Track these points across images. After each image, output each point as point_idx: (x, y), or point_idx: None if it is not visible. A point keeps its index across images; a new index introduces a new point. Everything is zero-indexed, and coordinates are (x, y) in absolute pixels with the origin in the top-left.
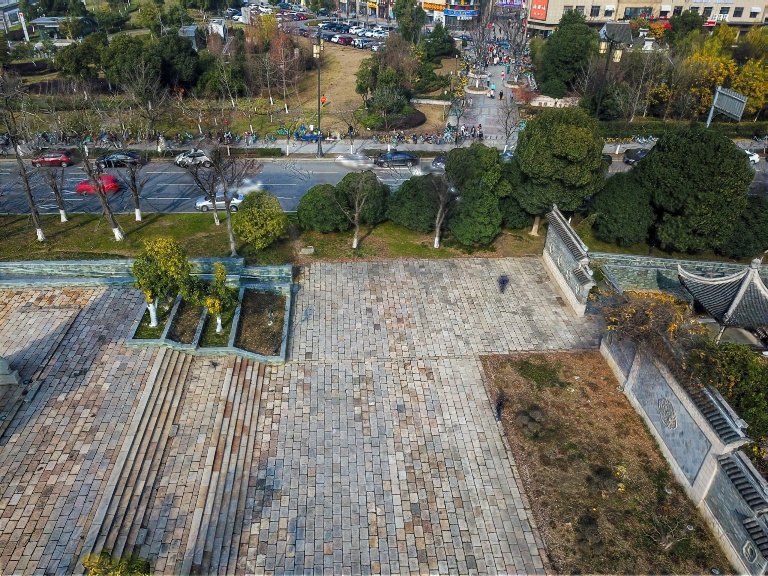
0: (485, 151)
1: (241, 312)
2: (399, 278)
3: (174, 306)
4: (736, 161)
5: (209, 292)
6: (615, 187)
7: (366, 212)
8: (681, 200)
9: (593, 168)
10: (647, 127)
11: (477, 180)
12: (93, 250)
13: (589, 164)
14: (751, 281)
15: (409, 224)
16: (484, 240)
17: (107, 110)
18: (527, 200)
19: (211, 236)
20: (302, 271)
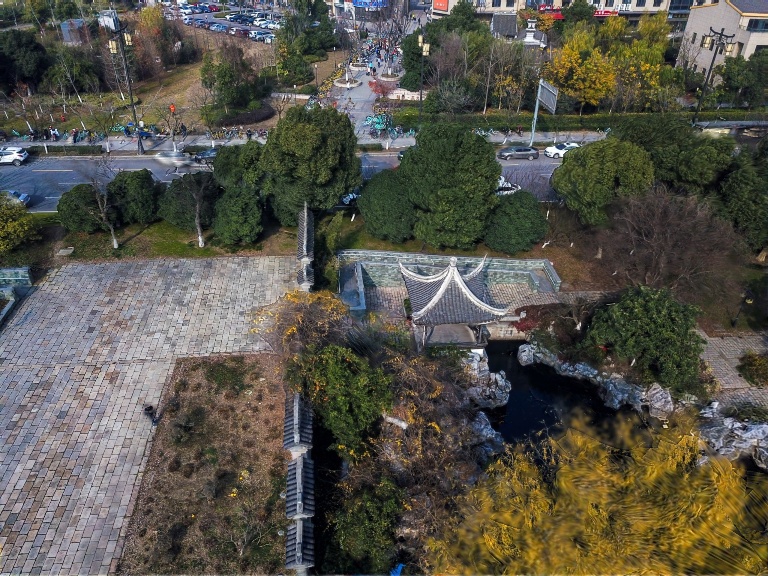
0: (246, 148)
1: None
2: (145, 279)
3: None
4: (479, 157)
5: None
6: (377, 184)
7: (137, 211)
8: (426, 197)
9: (330, 165)
10: (491, 120)
11: (236, 178)
12: None
13: (323, 162)
14: (452, 279)
15: (177, 223)
16: (246, 239)
17: None
18: (283, 198)
19: None
20: (49, 273)
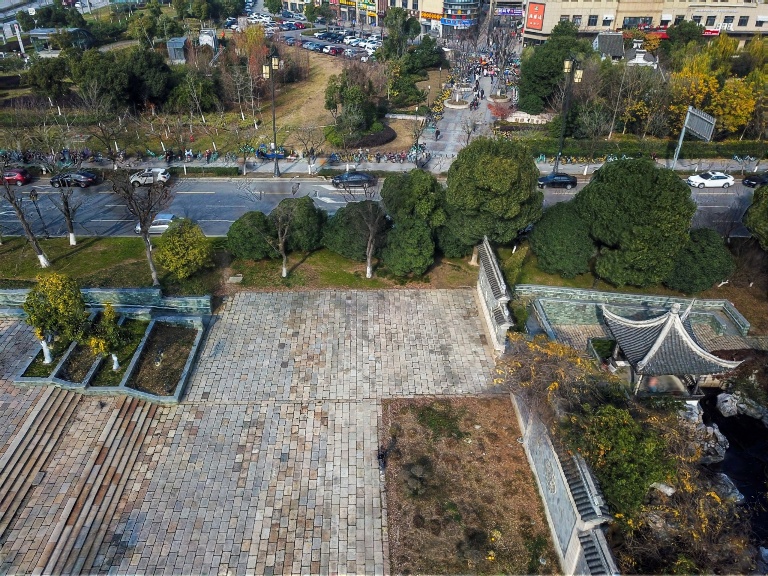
0: (419, 179)
1: (144, 347)
2: (322, 311)
3: (74, 341)
4: (675, 194)
5: (98, 331)
6: (554, 217)
7: (300, 239)
8: (616, 234)
9: (521, 200)
10: (622, 146)
11: (409, 209)
12: (16, 277)
13: (516, 196)
14: (672, 326)
15: (343, 252)
16: (416, 271)
17: (38, 135)
18: (459, 231)
19: (139, 263)
20: (225, 301)
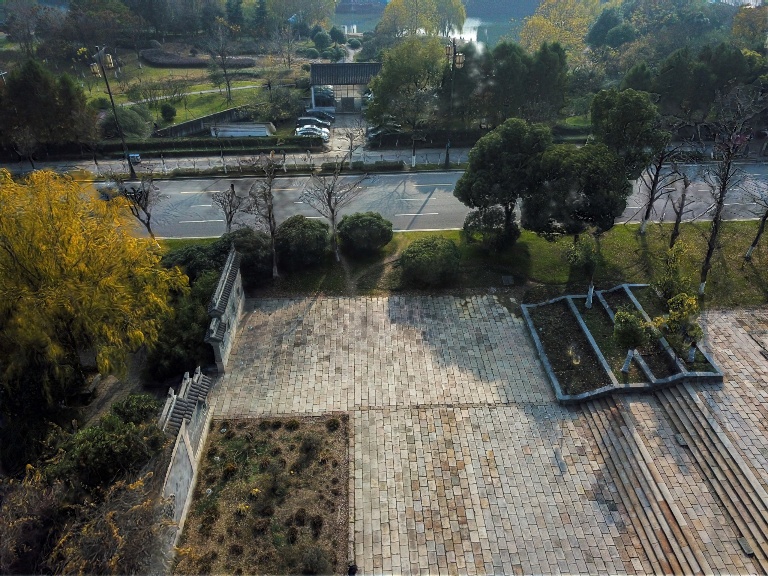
0: None
1: None
2: None
3: None
4: None
5: None
6: None
7: None
8: None
9: None
10: None
11: None
12: None
13: None
14: None
15: None
16: None
17: None
18: None
19: None
20: None
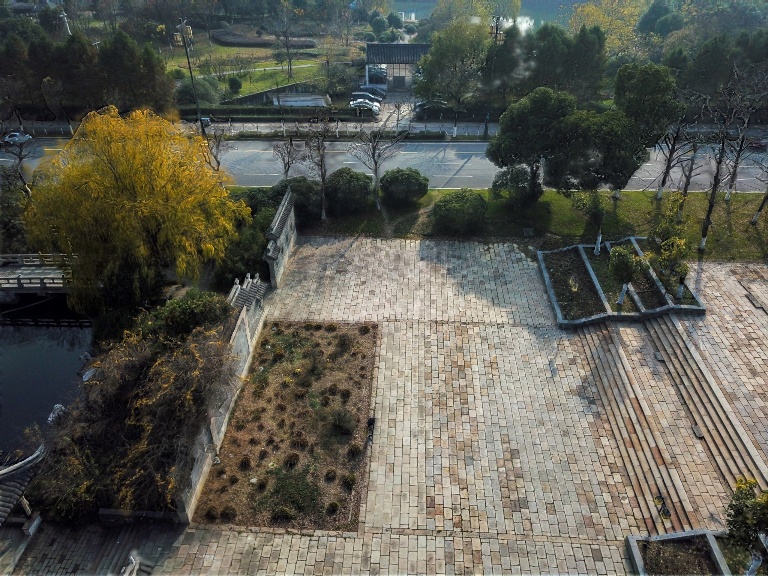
0: None
1: None
2: None
3: None
4: None
5: None
6: None
7: None
8: None
9: None
10: None
11: None
12: None
13: None
14: None
15: None
16: None
17: None
18: None
19: None
20: None
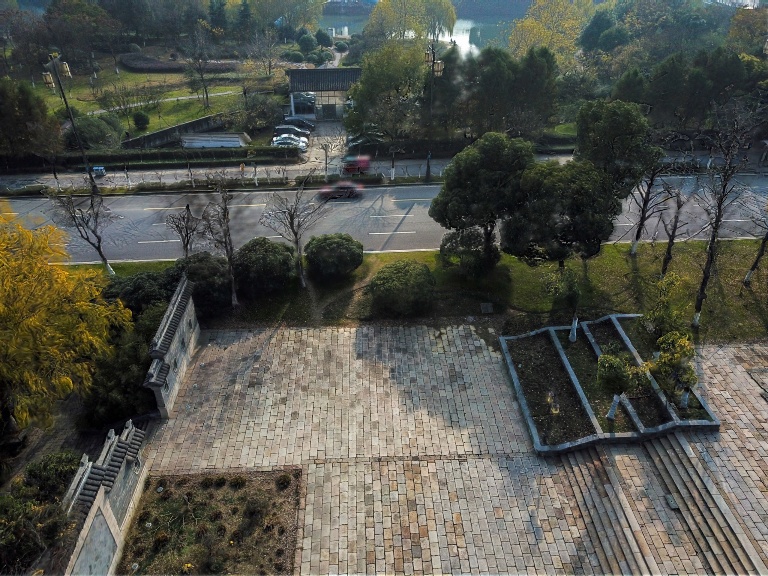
0: None
1: None
2: None
3: None
4: None
5: None
6: None
7: None
8: None
9: None
10: None
11: None
12: None
13: None
14: None
15: None
16: None
17: None
18: None
19: None
20: None
